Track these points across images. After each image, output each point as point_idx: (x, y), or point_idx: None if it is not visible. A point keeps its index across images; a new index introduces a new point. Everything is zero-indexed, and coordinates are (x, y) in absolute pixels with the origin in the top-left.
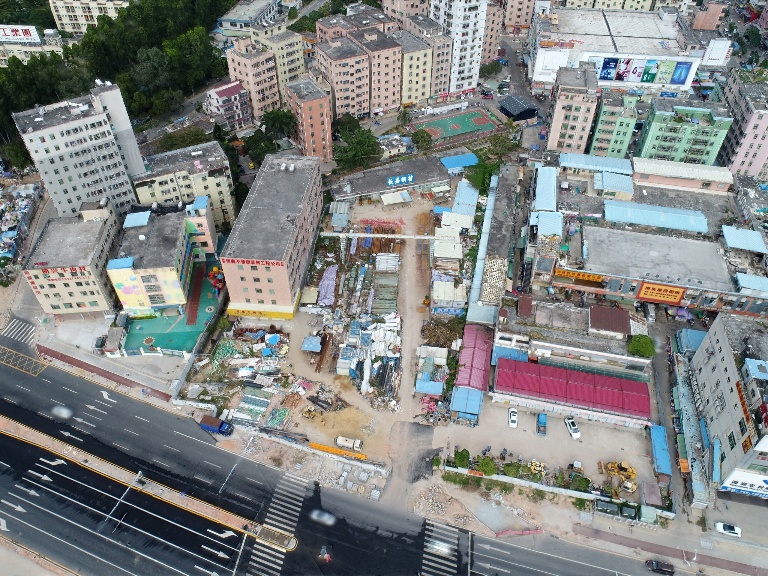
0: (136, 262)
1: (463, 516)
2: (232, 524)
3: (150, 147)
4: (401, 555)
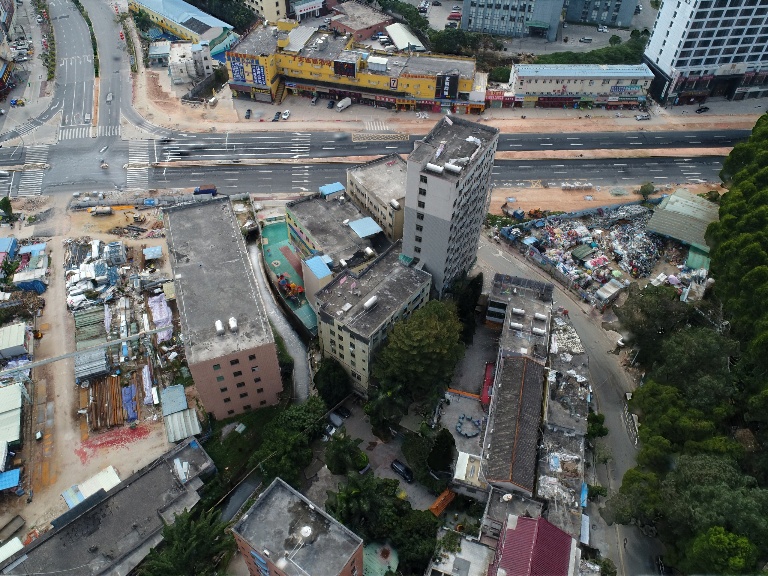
0: (329, 204)
1: (13, 201)
2: (167, 162)
3: (518, 373)
4: (56, 178)
